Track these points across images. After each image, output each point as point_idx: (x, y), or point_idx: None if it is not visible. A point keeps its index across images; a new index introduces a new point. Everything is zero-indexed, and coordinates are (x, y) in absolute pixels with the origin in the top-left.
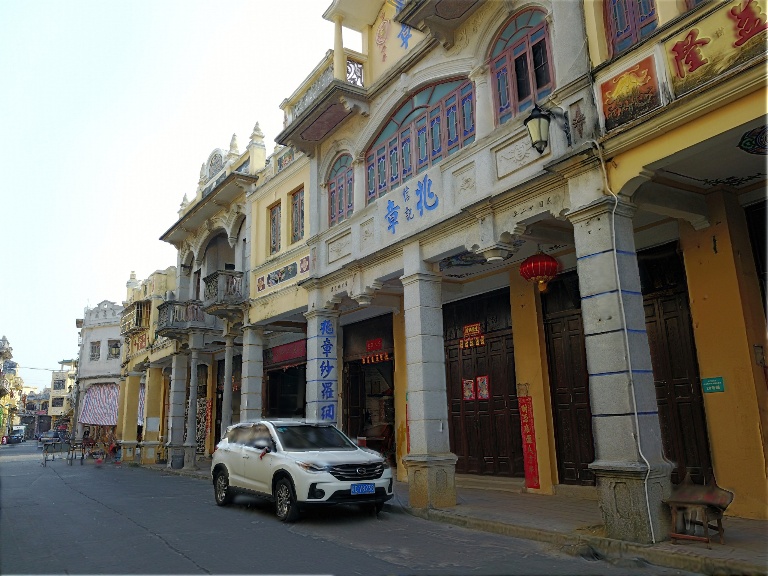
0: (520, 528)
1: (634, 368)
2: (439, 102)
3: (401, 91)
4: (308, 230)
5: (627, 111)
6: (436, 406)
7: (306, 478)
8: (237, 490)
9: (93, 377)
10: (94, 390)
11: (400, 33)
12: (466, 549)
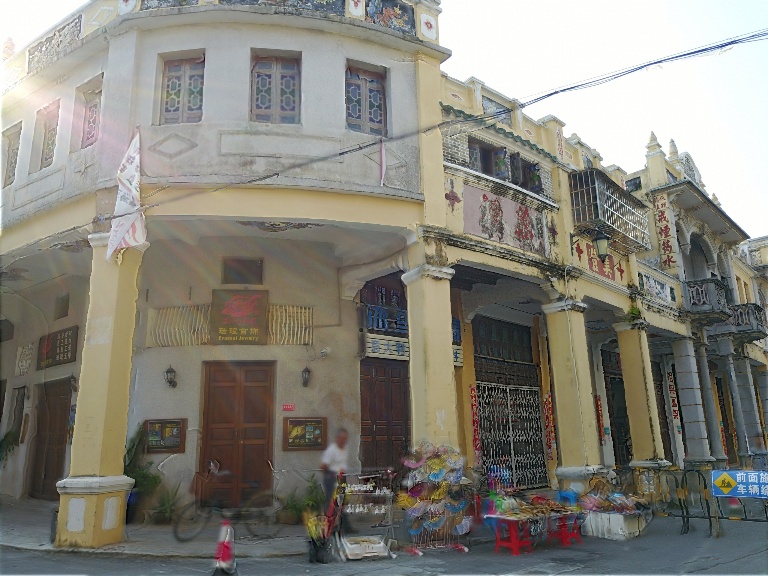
0: None
1: None
2: None
3: None
4: None
5: None
6: None
7: None
8: None
9: None
10: None
11: None
12: None
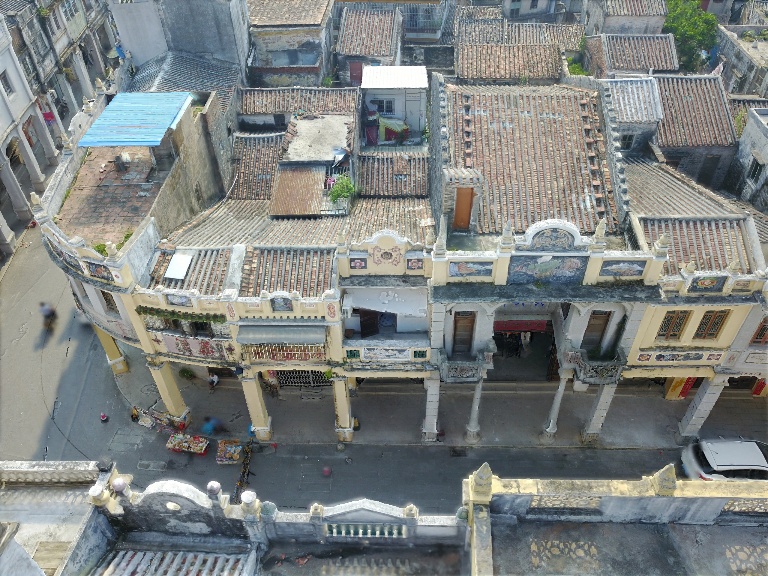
0: None
1: None
2: None
3: None
4: (726, 339)
5: None
6: None
7: None
8: None
9: None
10: None
11: None
12: None
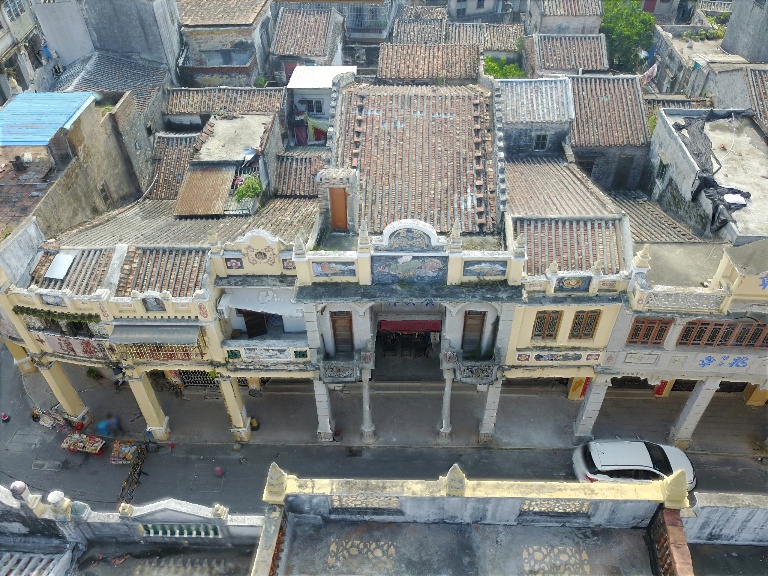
0: (736, 454)
1: None
2: (767, 323)
3: (747, 310)
4: (602, 339)
5: None
6: None
7: None
8: None
9: None
10: None
11: (763, 278)
12: (745, 478)
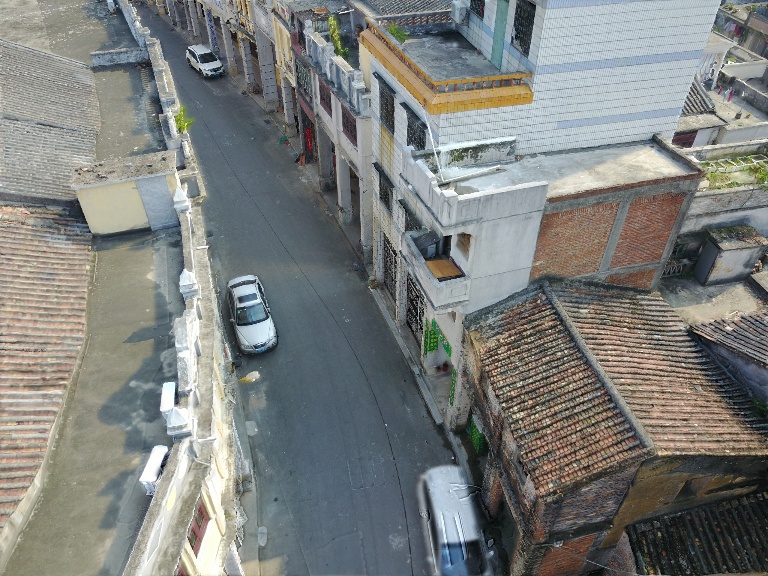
0: None
1: (248, 67)
2: None
3: None
4: None
5: (242, 24)
6: (231, 54)
7: (204, 72)
8: (193, 67)
9: None
10: None
11: None
12: None
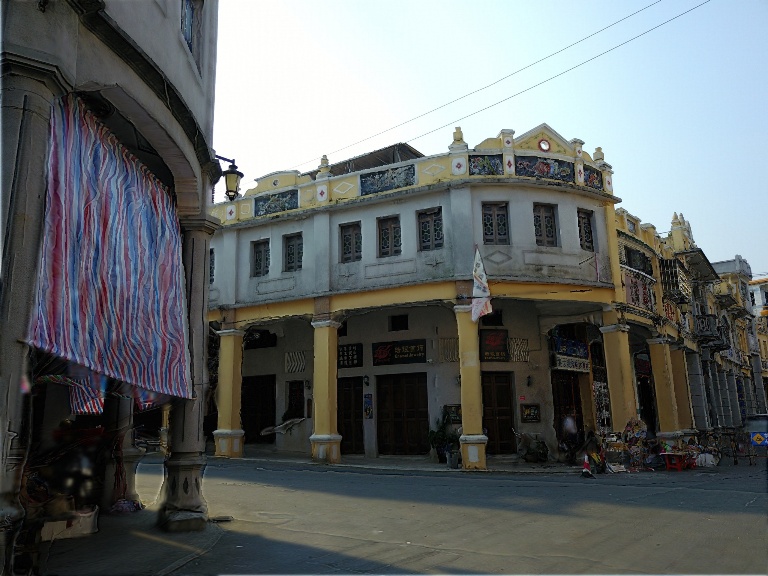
0: None
1: None
2: None
3: None
4: None
5: None
6: None
7: None
8: None
9: (155, 71)
10: (79, 130)
11: None
12: None
